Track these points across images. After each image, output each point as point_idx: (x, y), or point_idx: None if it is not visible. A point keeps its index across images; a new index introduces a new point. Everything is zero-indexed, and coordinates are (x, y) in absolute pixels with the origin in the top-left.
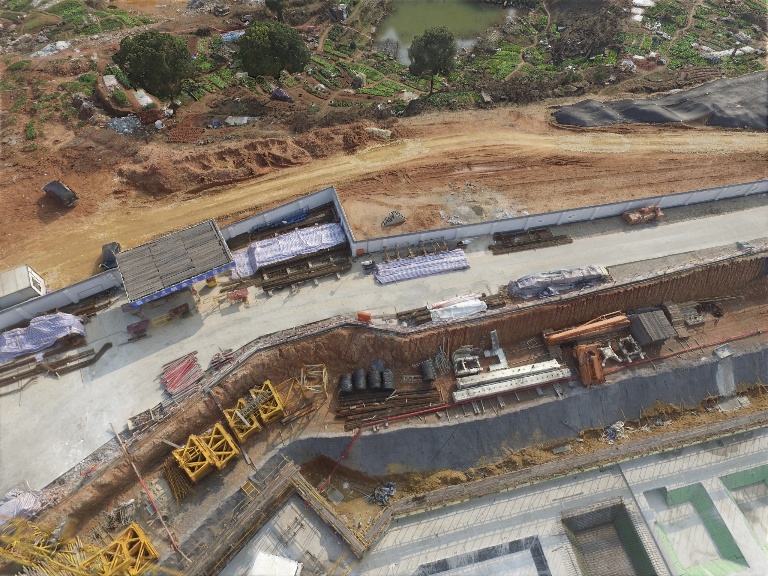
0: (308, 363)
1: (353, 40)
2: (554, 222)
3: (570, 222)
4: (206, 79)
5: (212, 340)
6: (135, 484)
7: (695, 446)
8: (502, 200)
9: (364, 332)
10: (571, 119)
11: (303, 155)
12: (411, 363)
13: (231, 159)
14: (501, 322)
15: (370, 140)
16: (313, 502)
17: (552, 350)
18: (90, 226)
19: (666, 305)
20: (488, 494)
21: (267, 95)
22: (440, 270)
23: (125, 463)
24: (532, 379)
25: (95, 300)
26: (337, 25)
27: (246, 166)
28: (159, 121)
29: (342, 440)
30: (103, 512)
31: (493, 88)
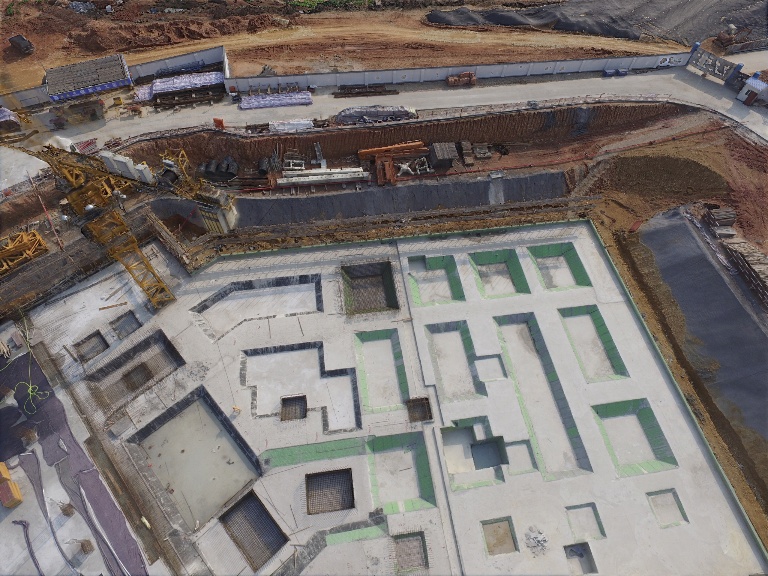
0: (177, 155)
1: None
2: (390, 81)
3: (403, 82)
4: None
5: (109, 133)
6: (41, 213)
7: (458, 235)
8: (357, 67)
9: (219, 135)
10: (439, 18)
11: (214, 32)
12: (253, 161)
13: (157, 32)
14: (323, 137)
15: (271, 26)
16: (157, 228)
17: (363, 163)
18: (40, 67)
19: (461, 142)
20: (292, 248)
21: None
22: (288, 103)
23: (34, 195)
24: (338, 175)
25: (33, 108)
26: None
27: (165, 35)
28: (109, 6)
29: (191, 203)
30: (17, 226)
31: None
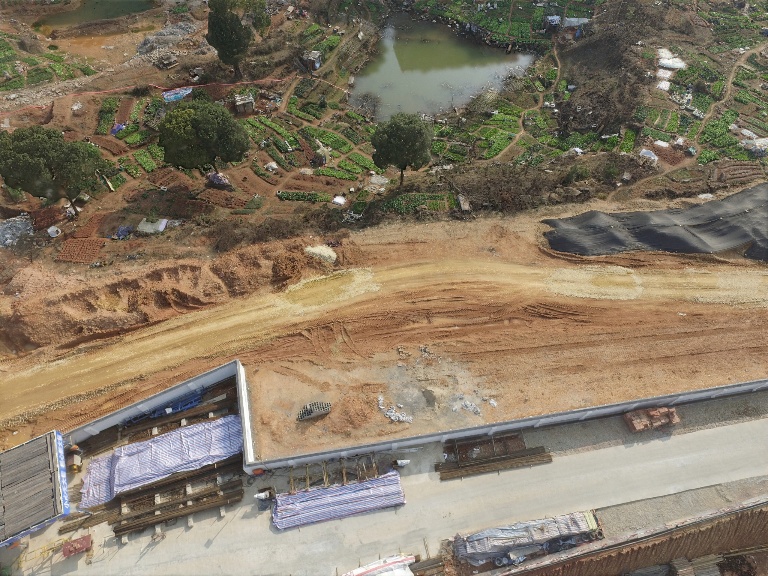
0: None
1: (324, 95)
2: (529, 424)
3: (551, 424)
4: (132, 157)
5: None
6: None
7: None
8: (464, 379)
9: None
10: (568, 245)
11: (218, 290)
12: None
13: (127, 293)
14: None
15: (308, 267)
16: None
17: None
18: None
19: (676, 567)
20: None
21: (203, 180)
22: (362, 509)
23: None
24: None
25: None
26: (307, 77)
27: (139, 310)
28: (53, 228)
29: None
30: None
31: (474, 189)
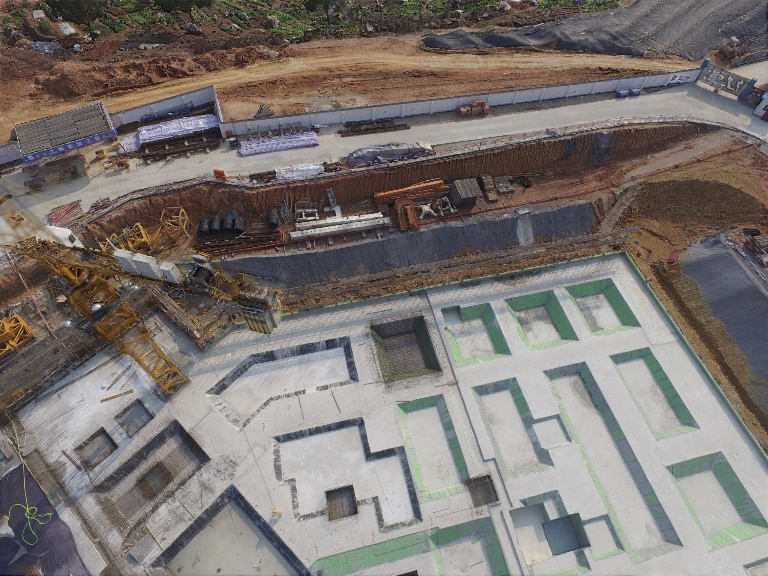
0: (175, 213)
1: None
2: (398, 115)
3: (412, 115)
4: (129, 17)
5: (95, 193)
6: (23, 292)
7: (491, 279)
8: (360, 100)
9: (221, 187)
10: (437, 43)
11: (198, 69)
12: (260, 213)
13: (135, 72)
14: (336, 182)
15: (260, 59)
16: (162, 301)
17: (381, 207)
18: (5, 118)
19: (482, 176)
20: (314, 309)
21: (183, 31)
22: (293, 146)
23: (13, 272)
24: (357, 224)
25: (2, 168)
26: None
27: (145, 75)
28: (77, 44)
29: None
30: None
31: (377, 21)
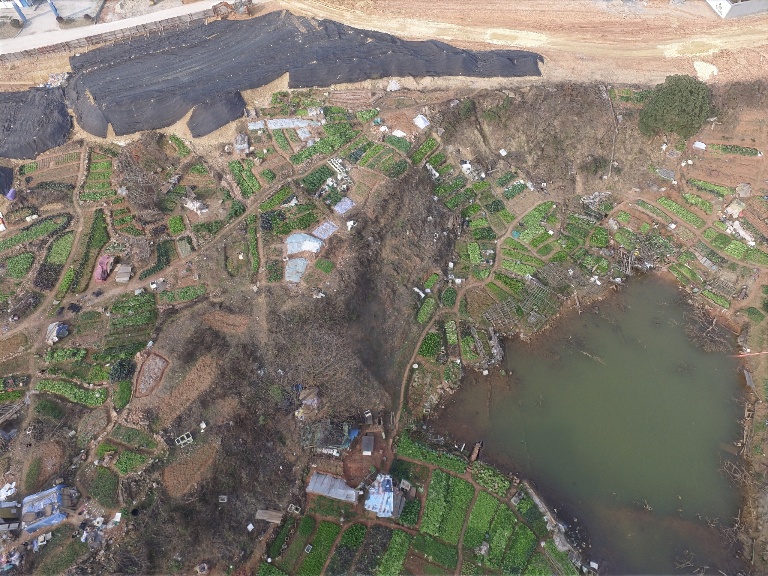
0: None
1: None
2: None
3: None
4: None
5: None
6: None
7: None
8: (603, 6)
9: None
10: None
11: None
12: None
13: None
14: None
15: (710, 61)
16: None
17: None
18: None
19: None
20: None
21: None
22: None
23: None
24: None
25: None
26: None
27: None
28: None
29: None
30: None
31: None
